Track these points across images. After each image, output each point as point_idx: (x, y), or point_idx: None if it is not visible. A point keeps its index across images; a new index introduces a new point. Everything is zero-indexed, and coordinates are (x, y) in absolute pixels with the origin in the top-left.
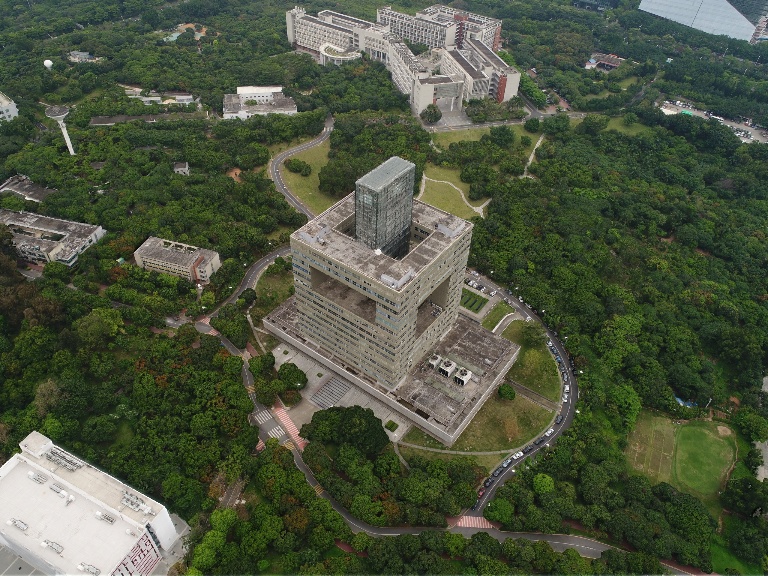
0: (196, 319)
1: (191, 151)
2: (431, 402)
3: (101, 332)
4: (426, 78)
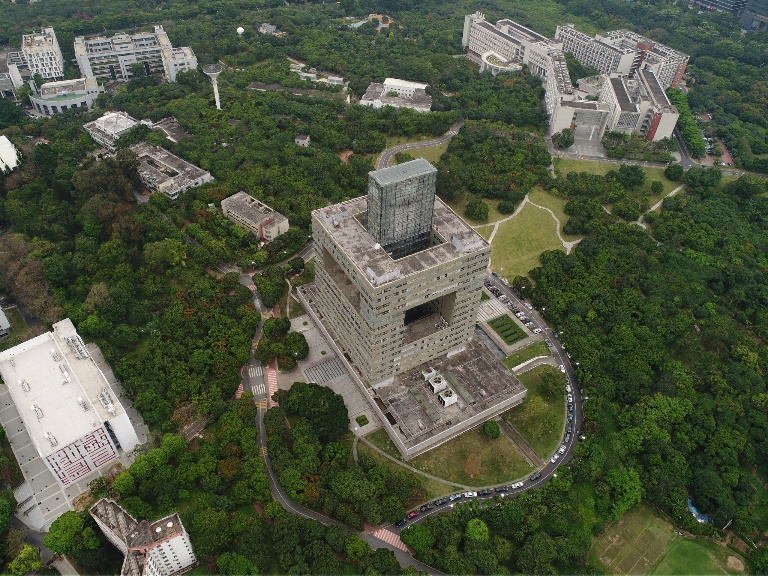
0: (246, 271)
1: (315, 126)
2: (405, 411)
3: (163, 259)
4: (570, 101)
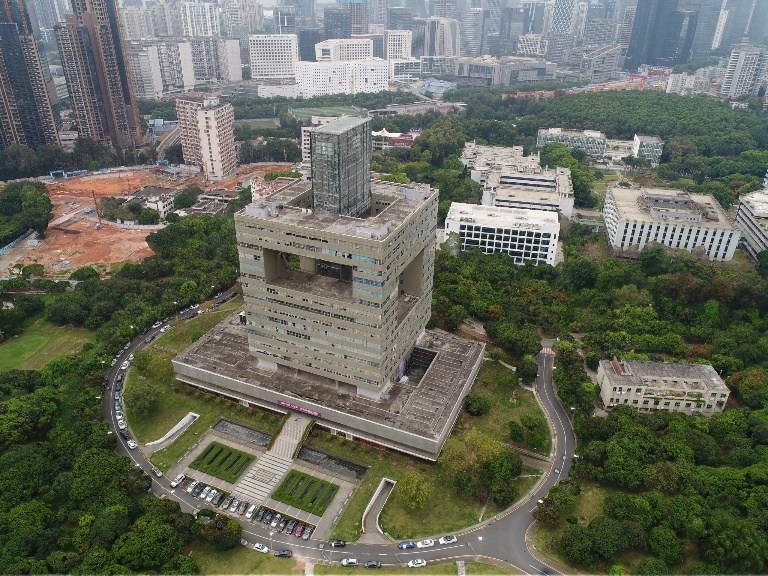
0: None
1: None
2: None
3: None
4: None
